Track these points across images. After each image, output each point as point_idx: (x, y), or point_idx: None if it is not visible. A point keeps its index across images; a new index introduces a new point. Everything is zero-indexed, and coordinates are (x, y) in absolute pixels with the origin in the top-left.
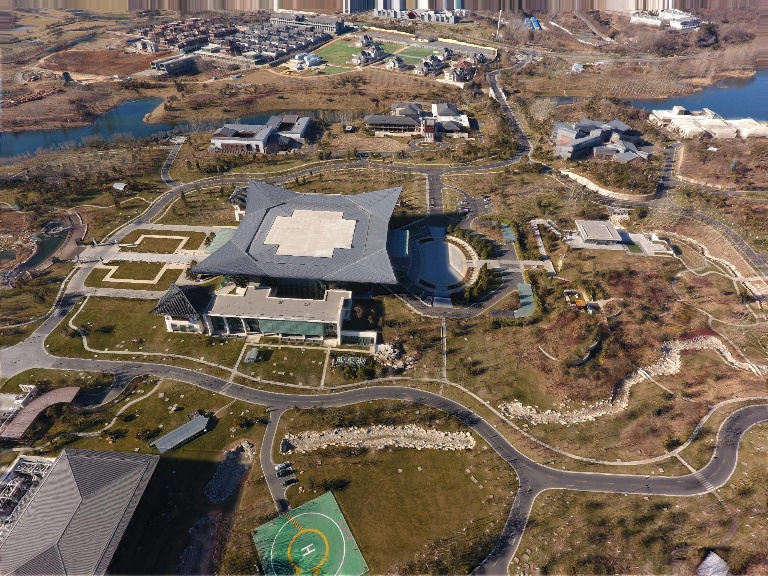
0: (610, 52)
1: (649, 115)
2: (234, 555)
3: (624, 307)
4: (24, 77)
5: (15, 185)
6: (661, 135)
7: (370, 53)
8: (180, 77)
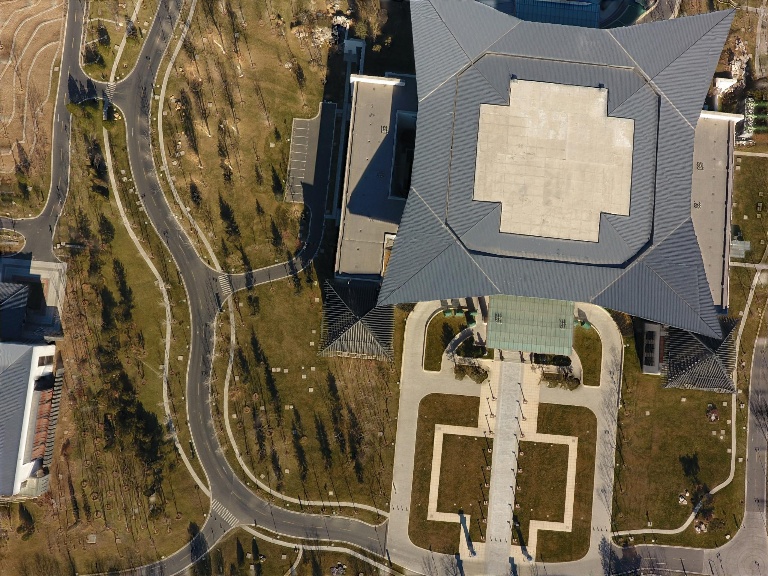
0: None
1: None
2: None
3: None
4: None
5: None
6: None
7: None
8: None
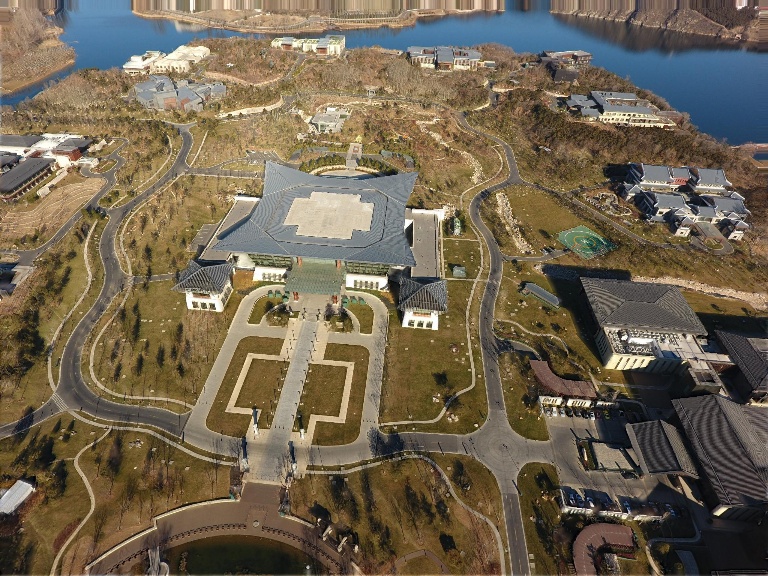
0: None
1: None
2: (601, 264)
3: None
4: None
5: None
6: (180, 74)
7: None
8: None
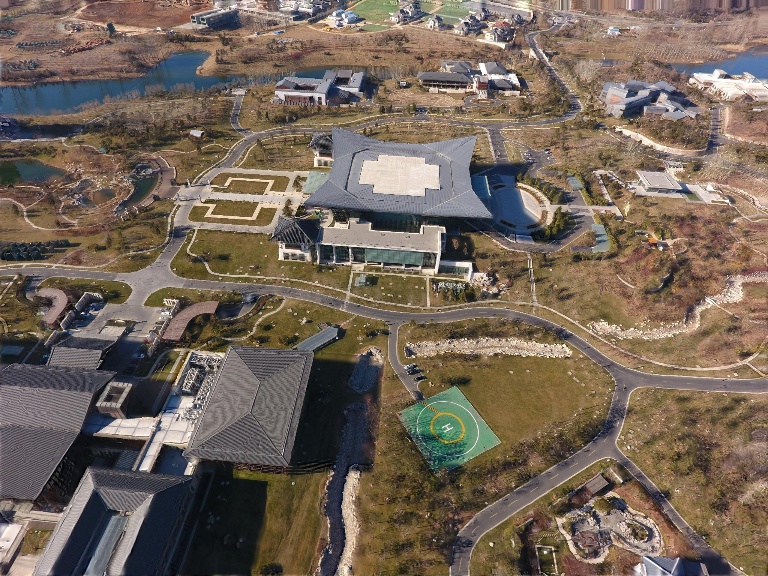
0: (644, 16)
1: (689, 78)
2: None
3: (690, 246)
4: (67, 27)
5: (95, 130)
6: (705, 97)
7: (408, 11)
8: (221, 31)
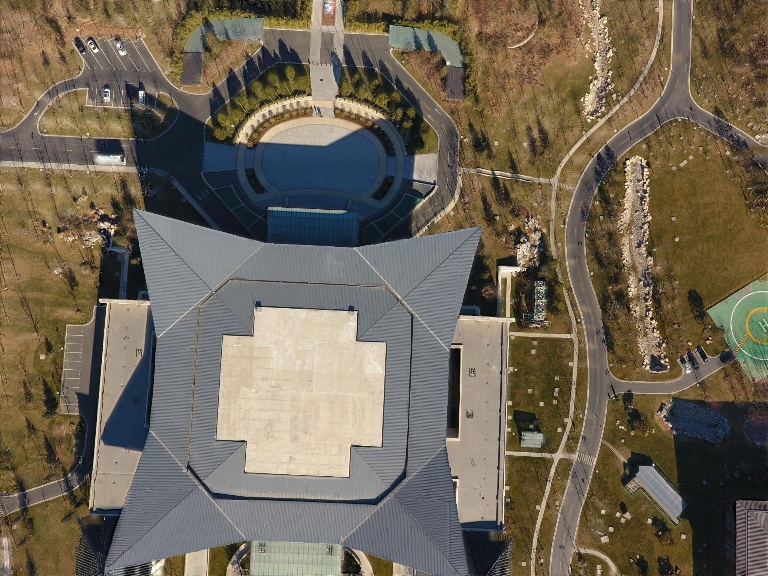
0: None
1: None
2: None
3: None
4: None
5: None
6: None
7: None
8: None
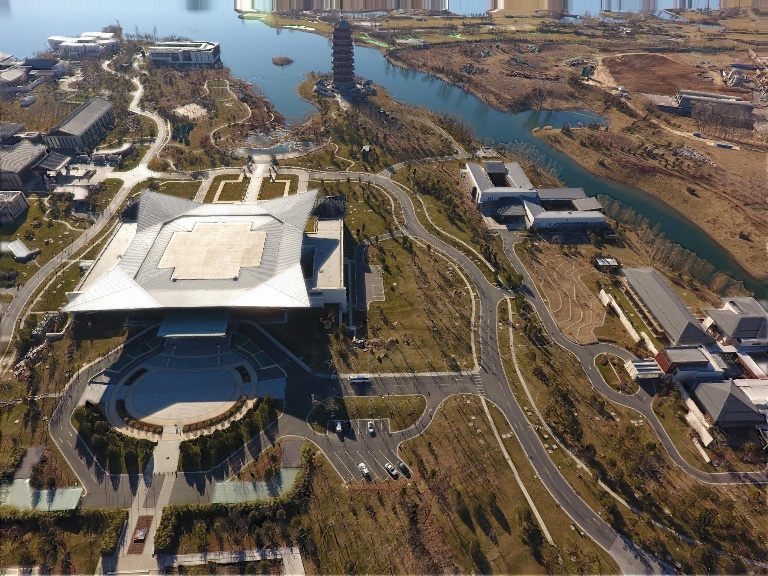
0: None
1: None
2: None
3: None
4: None
5: None
6: None
7: None
8: (682, 117)
